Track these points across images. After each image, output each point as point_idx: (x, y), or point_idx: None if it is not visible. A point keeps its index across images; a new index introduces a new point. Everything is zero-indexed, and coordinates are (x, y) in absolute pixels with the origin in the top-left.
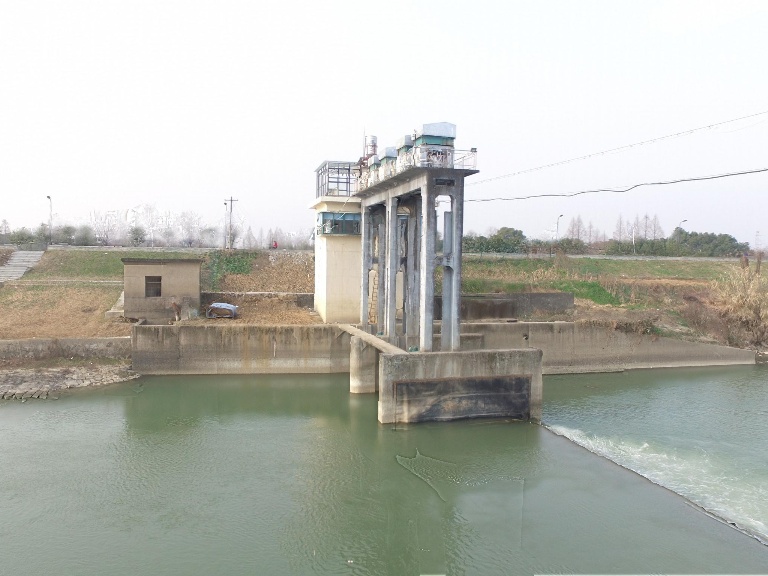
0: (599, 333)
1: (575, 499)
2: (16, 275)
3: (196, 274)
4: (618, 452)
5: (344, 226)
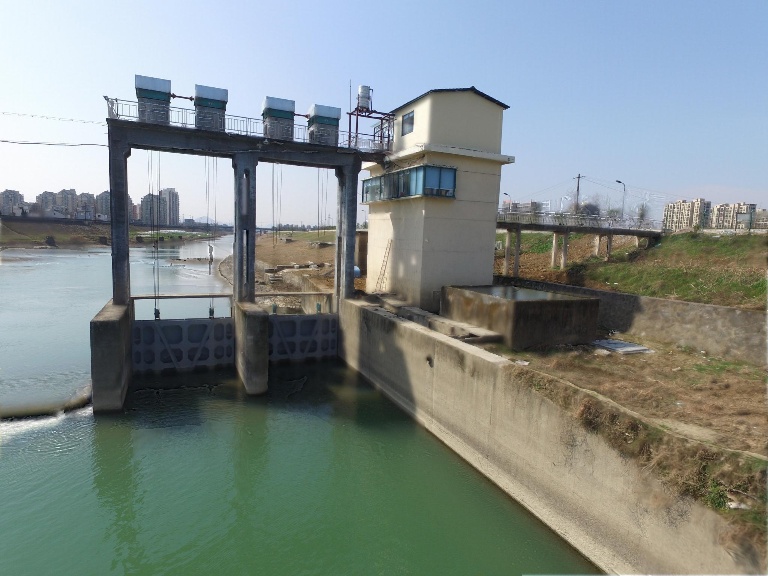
0: (546, 416)
1: None
2: None
3: (357, 243)
4: None
5: (371, 192)
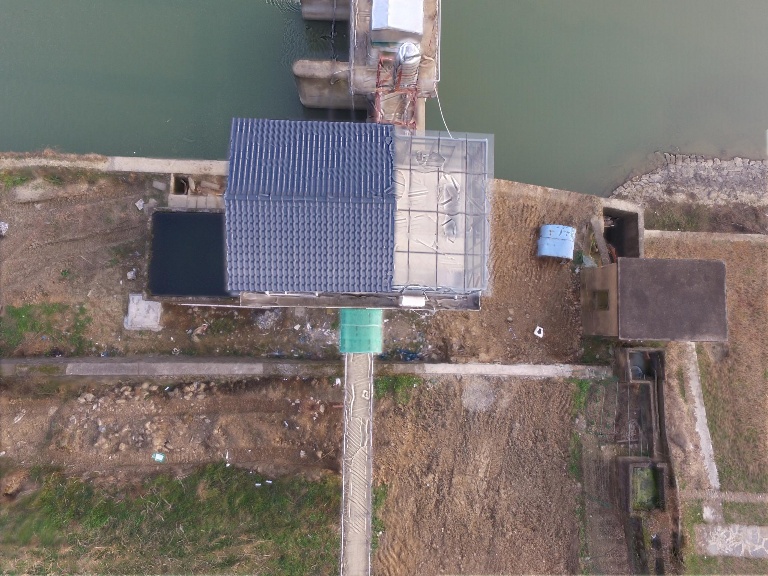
0: None
1: None
2: None
3: None
4: None
5: None
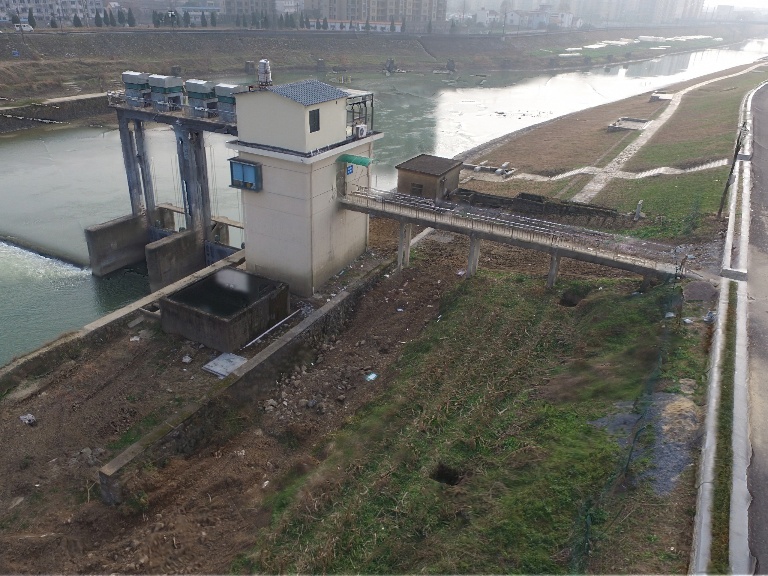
0: None
1: (64, 234)
2: (641, 176)
3: None
4: (44, 271)
5: None
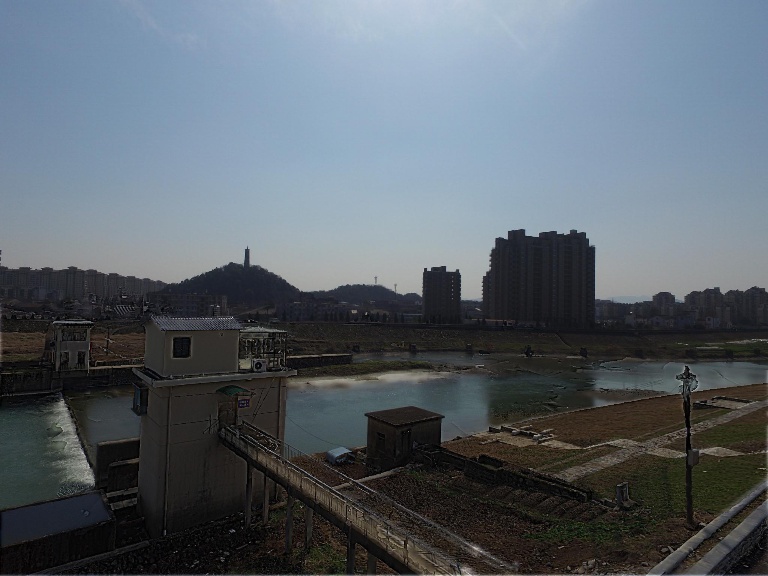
0: None
1: None
2: None
3: None
4: (71, 477)
5: None
